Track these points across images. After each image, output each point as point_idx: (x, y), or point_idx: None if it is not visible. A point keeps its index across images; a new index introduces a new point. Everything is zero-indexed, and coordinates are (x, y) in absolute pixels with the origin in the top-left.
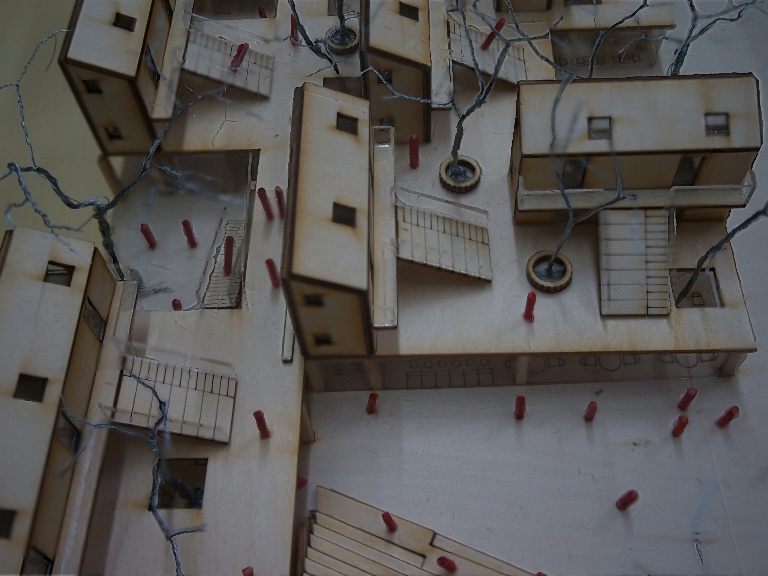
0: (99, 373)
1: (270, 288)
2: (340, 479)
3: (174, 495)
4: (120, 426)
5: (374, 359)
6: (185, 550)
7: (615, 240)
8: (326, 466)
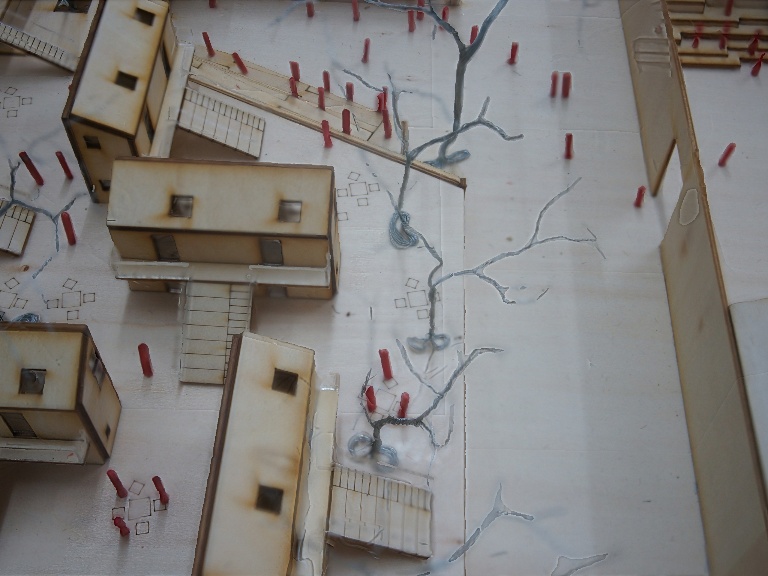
0: None
1: None
2: (184, 37)
3: (71, 8)
4: None
5: None
6: (73, 30)
7: None
8: (177, 30)
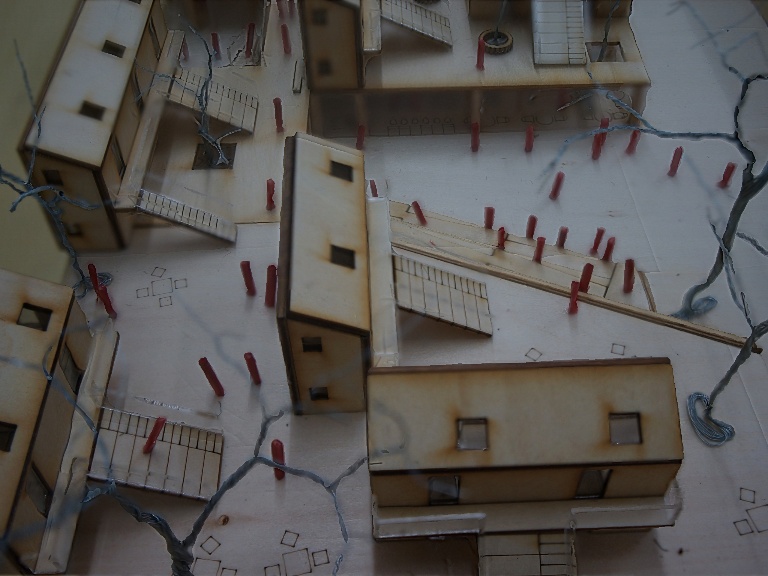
0: (157, 76)
1: (283, 55)
2: None
3: (211, 164)
4: (173, 105)
5: (363, 93)
6: (220, 190)
7: (543, 12)
8: None
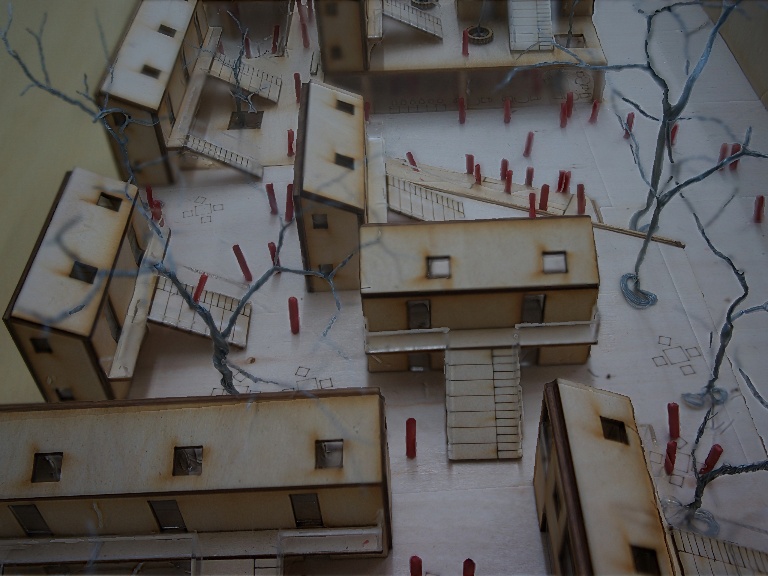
0: (200, 58)
1: (302, 48)
2: None
3: None
4: (213, 79)
5: (368, 75)
6: (250, 143)
7: (518, 10)
8: None
